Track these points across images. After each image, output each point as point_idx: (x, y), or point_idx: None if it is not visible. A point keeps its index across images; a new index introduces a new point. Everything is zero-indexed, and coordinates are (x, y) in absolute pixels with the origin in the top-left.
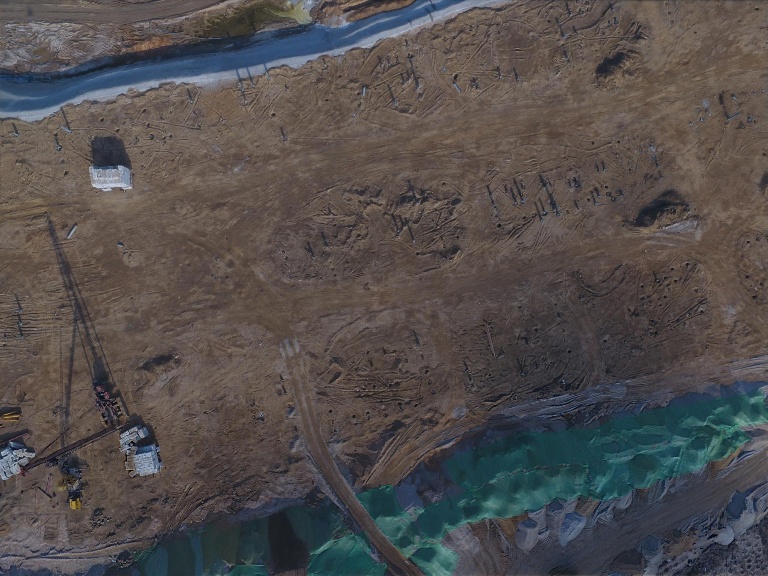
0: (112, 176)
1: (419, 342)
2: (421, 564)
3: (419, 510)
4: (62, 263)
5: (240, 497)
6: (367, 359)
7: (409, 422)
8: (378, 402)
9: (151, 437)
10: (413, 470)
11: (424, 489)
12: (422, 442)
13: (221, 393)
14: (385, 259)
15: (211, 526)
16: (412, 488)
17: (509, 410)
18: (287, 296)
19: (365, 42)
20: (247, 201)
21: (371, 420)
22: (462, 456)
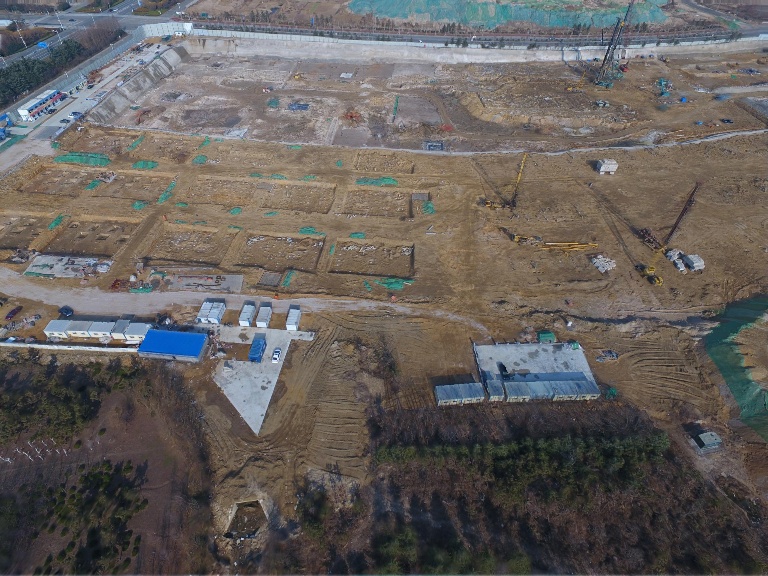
0: (614, 161)
1: None
2: None
3: None
4: (590, 194)
5: (765, 285)
6: None
7: None
8: None
9: None
10: None
11: None
12: None
13: (714, 241)
14: (765, 199)
15: (757, 298)
16: None
17: None
18: None
19: (695, 142)
20: (675, 179)
21: None
22: None
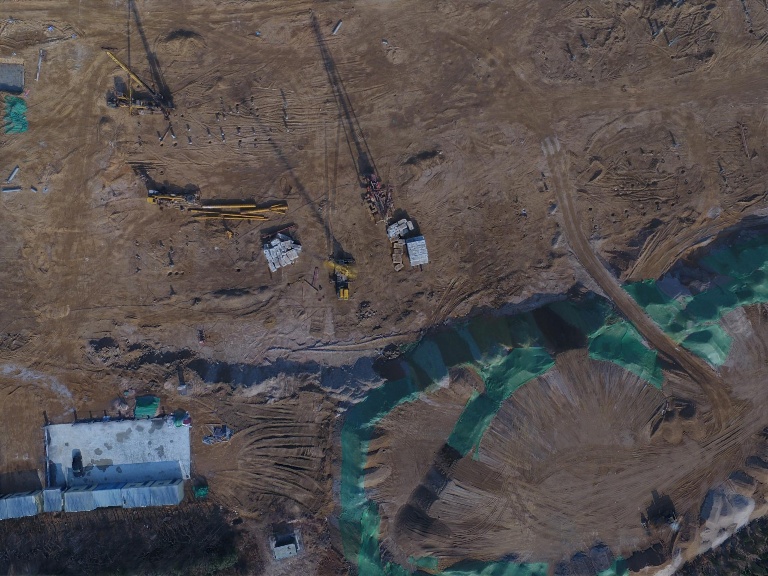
0: None
1: (675, 143)
2: (695, 347)
3: (688, 298)
4: (327, 59)
5: (504, 291)
6: (625, 159)
7: (667, 220)
8: (636, 201)
9: (416, 231)
10: (672, 267)
11: (689, 281)
12: (681, 239)
13: (484, 189)
14: (641, 62)
15: (476, 319)
16: (676, 281)
17: (762, 211)
18: (547, 96)
19: None
20: (508, 2)
21: (630, 218)
22: (720, 253)
